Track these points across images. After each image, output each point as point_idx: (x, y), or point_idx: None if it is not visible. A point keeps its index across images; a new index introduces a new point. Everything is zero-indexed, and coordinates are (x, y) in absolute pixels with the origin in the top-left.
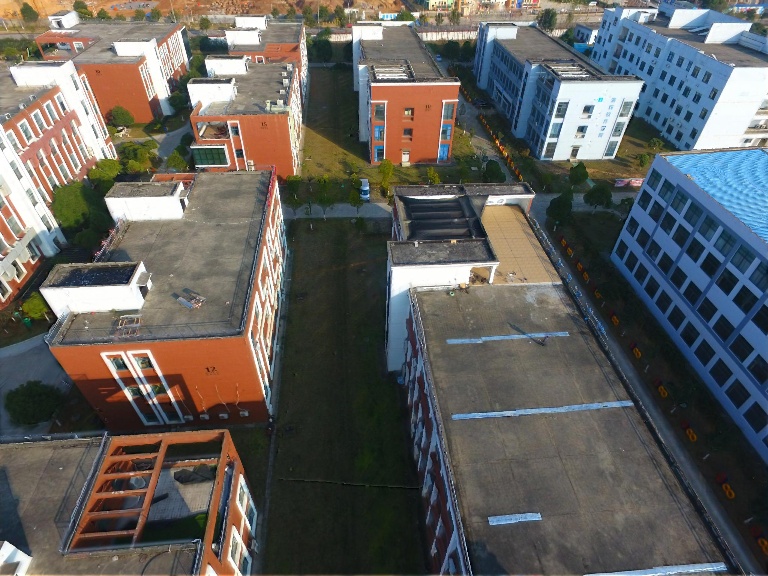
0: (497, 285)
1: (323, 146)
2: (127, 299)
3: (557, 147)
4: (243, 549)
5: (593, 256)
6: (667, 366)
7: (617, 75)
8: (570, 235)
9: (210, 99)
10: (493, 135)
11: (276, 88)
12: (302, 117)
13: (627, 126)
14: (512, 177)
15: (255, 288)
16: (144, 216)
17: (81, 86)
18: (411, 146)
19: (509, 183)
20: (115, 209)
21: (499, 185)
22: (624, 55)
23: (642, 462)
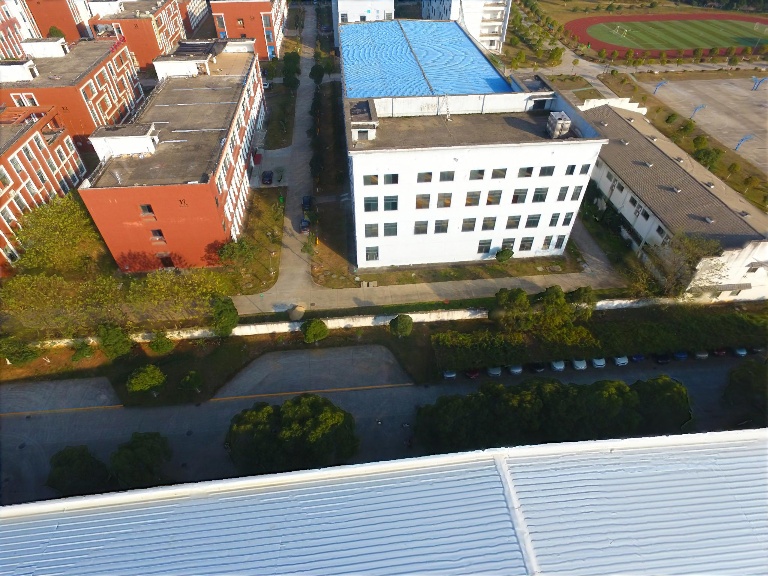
0: (212, 76)
1: None
2: (23, 74)
3: None
4: (70, 166)
5: None
6: (332, 136)
7: None
8: (328, 91)
9: (105, 13)
10: None
11: None
12: None
13: None
14: None
15: (91, 77)
16: (43, 55)
17: (20, 3)
18: None
19: (245, 38)
20: (27, 50)
21: (239, 39)
22: None
23: (223, 113)
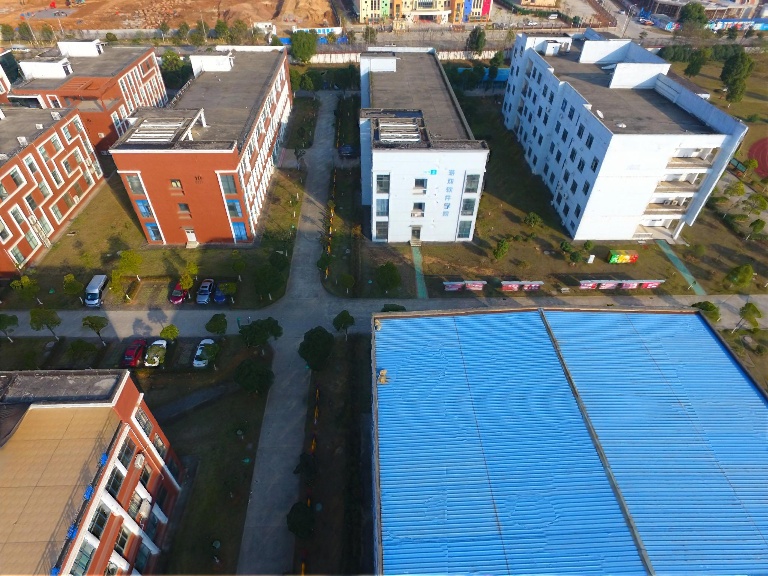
0: None
1: (105, 214)
2: None
3: (390, 227)
4: None
5: (346, 423)
6: None
7: (457, 139)
8: (339, 378)
9: None
10: (332, 200)
11: (6, 149)
12: (104, 170)
13: (514, 188)
14: (320, 269)
15: None
16: None
17: None
18: (193, 224)
19: (96, 371)
20: None
21: (80, 374)
22: (529, 94)
23: None
